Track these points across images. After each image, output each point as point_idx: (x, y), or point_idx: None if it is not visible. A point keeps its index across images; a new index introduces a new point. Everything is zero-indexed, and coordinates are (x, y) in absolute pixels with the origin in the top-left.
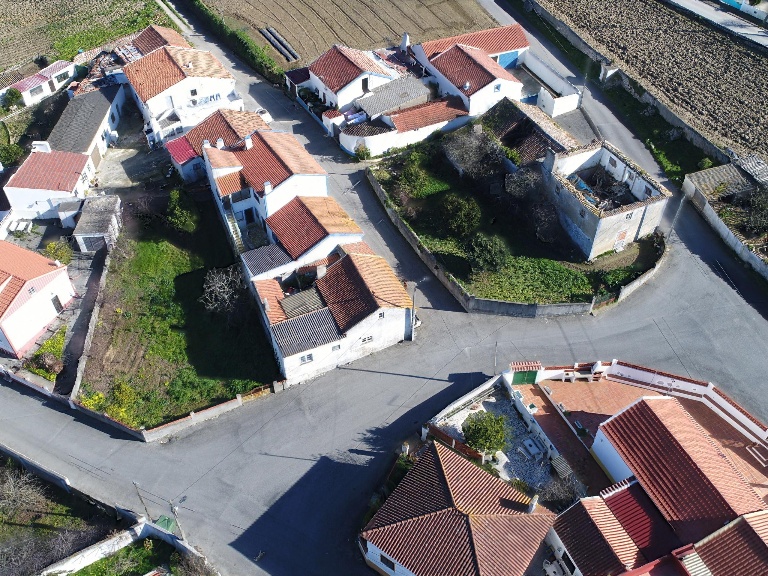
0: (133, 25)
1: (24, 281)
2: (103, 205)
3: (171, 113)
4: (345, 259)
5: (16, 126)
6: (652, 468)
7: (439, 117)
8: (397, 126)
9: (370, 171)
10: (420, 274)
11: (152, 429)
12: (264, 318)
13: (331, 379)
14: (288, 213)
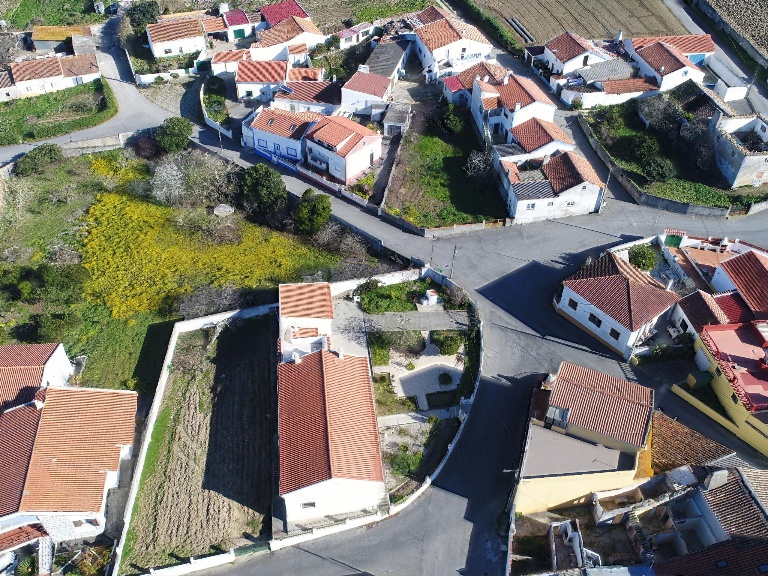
0: (412, 6)
1: (363, 136)
2: (401, 108)
3: (446, 61)
4: (564, 155)
5: (335, 60)
6: (749, 285)
7: (637, 88)
8: (606, 89)
9: (582, 115)
10: (609, 179)
11: (431, 228)
12: (504, 183)
13: (542, 225)
14: (526, 126)
